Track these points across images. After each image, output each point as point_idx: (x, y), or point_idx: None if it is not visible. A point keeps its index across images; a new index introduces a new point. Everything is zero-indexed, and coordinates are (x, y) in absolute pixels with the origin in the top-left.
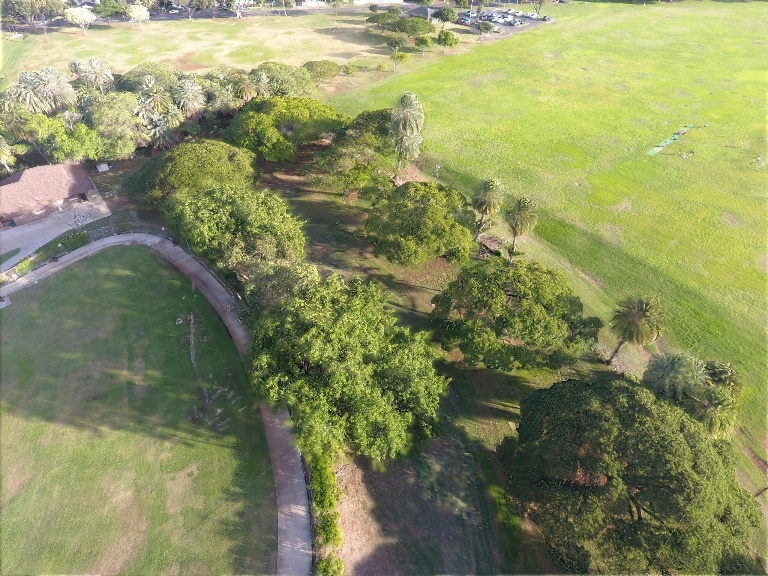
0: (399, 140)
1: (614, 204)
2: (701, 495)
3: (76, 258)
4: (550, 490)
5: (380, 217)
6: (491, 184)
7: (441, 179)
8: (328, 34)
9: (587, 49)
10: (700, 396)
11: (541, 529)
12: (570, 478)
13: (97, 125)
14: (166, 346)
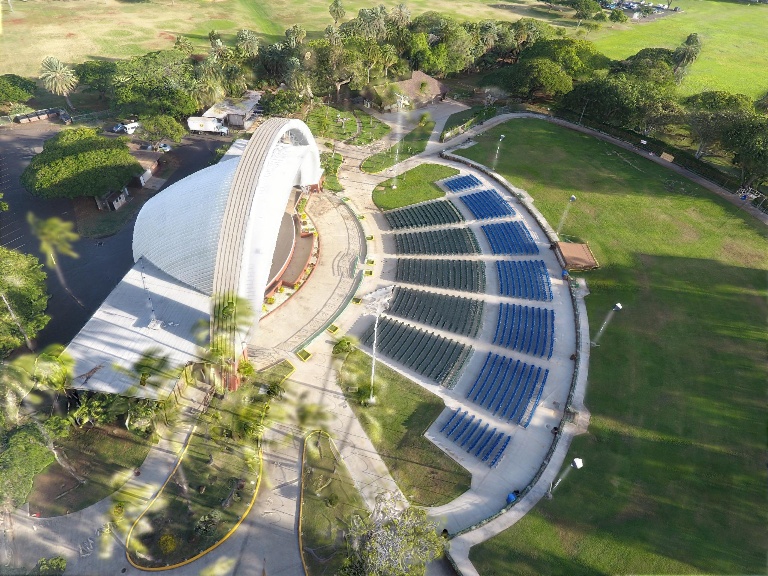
0: None
1: None
2: None
3: (495, 123)
4: None
5: None
6: None
7: (685, 105)
8: (503, 9)
9: (728, 33)
10: None
11: None
12: None
13: (449, 46)
14: (614, 163)
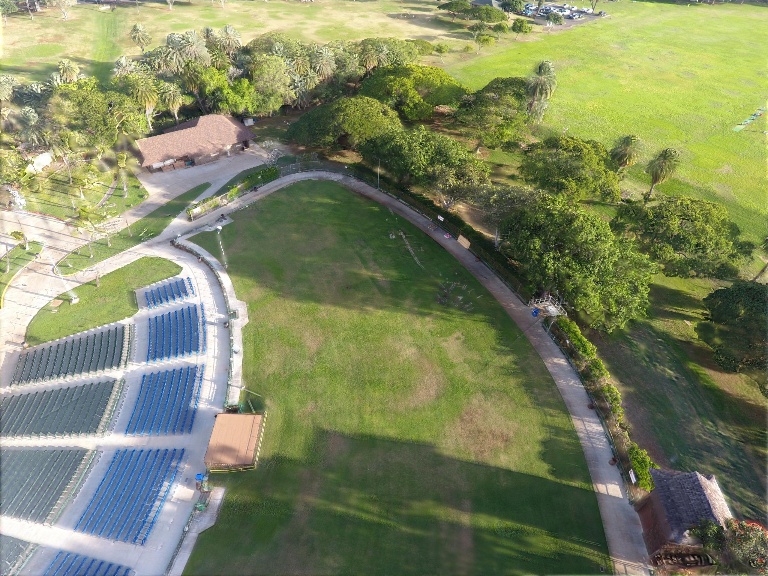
0: (528, 105)
1: (717, 168)
2: None
3: (273, 189)
4: (761, 348)
5: (536, 164)
6: (633, 138)
7: None
8: (401, 19)
9: (648, 42)
10: None
11: (755, 376)
12: None
13: (256, 81)
14: (390, 253)
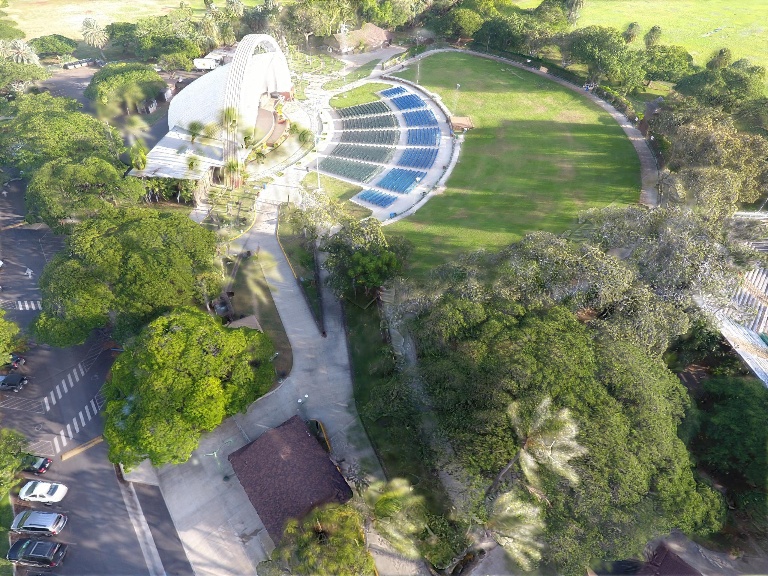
0: (568, 15)
1: None
2: (753, 81)
3: (424, 56)
4: None
5: None
6: (635, 24)
7: None
8: None
9: None
10: (749, 73)
11: None
12: (704, 88)
13: (393, 4)
14: (505, 75)
